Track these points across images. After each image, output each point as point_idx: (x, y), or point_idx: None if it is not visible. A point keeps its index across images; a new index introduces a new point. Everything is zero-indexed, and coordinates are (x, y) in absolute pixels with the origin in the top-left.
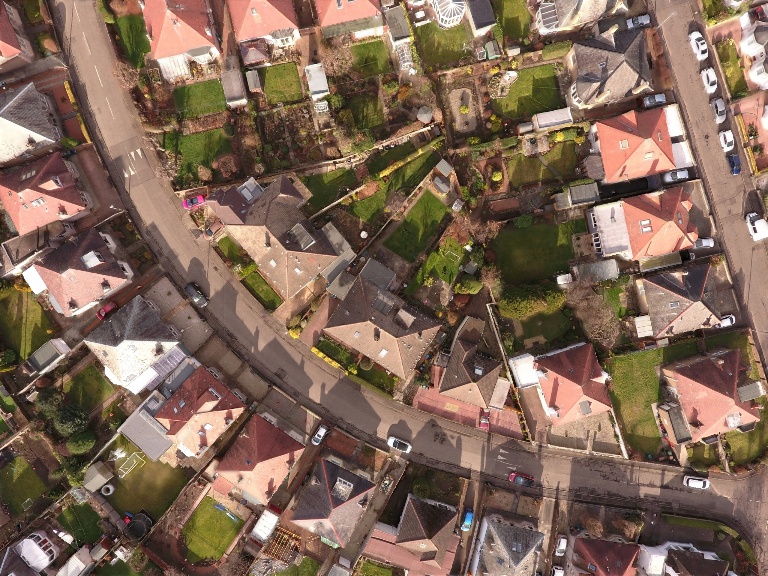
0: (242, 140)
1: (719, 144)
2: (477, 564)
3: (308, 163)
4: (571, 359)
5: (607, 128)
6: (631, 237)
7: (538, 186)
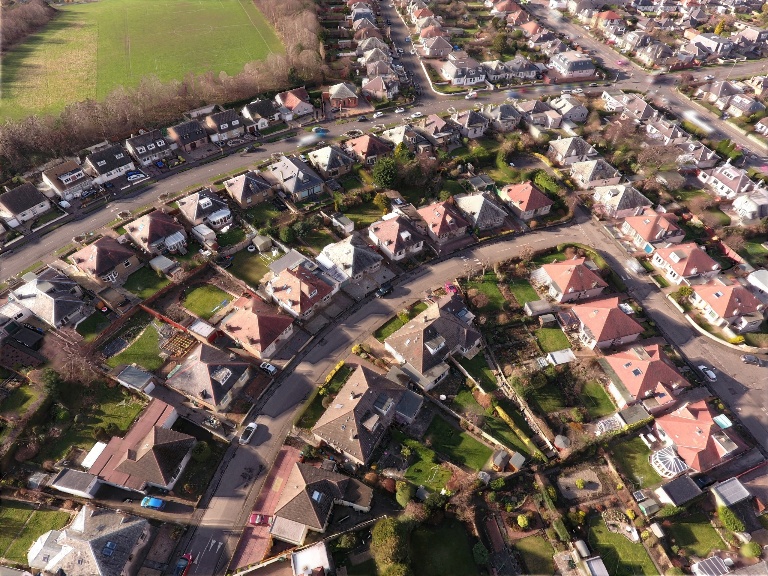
0: None
1: None
2: None
3: (495, 357)
4: None
5: None
6: None
7: (524, 575)
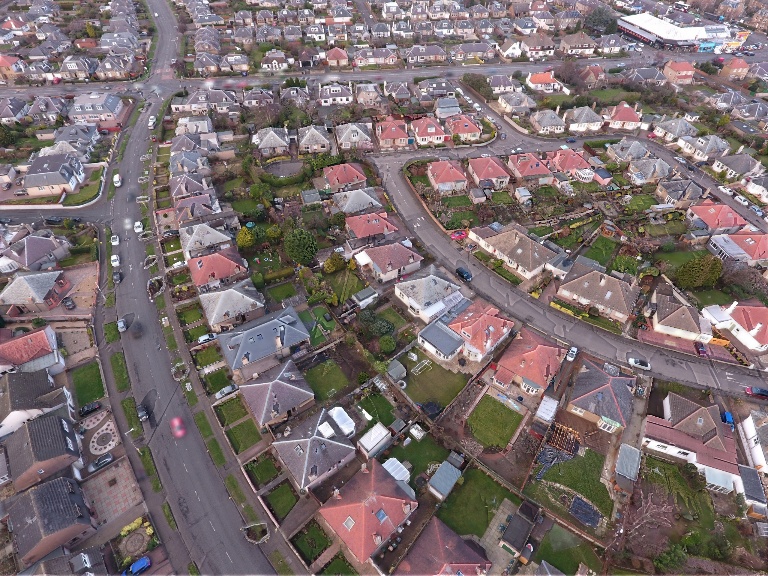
0: None
1: (767, 223)
2: (760, 447)
3: None
4: (747, 302)
5: (697, 207)
6: (744, 249)
7: (668, 236)
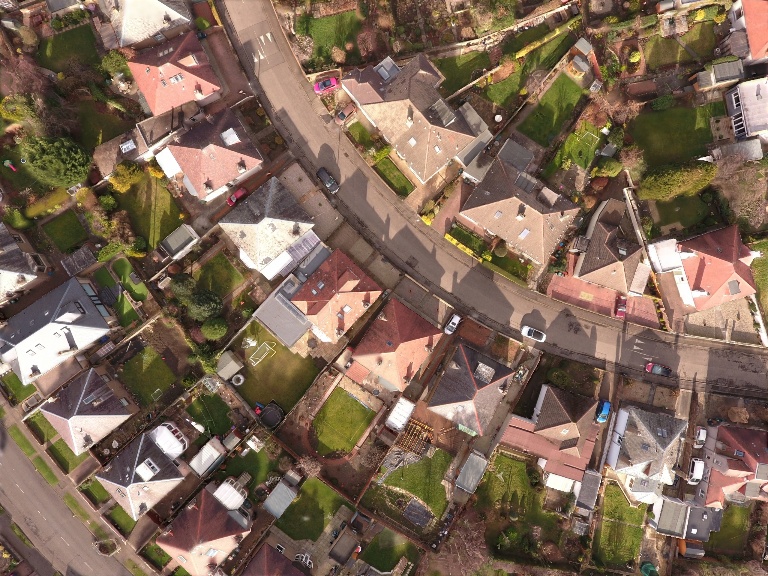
0: (373, 23)
1: None
2: (618, 453)
3: (440, 46)
4: (717, 239)
5: (754, 1)
6: None
7: (675, 68)
